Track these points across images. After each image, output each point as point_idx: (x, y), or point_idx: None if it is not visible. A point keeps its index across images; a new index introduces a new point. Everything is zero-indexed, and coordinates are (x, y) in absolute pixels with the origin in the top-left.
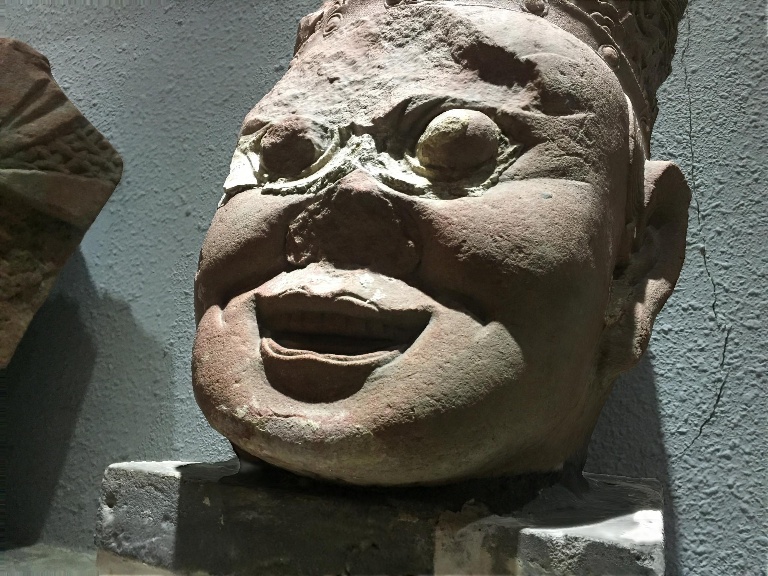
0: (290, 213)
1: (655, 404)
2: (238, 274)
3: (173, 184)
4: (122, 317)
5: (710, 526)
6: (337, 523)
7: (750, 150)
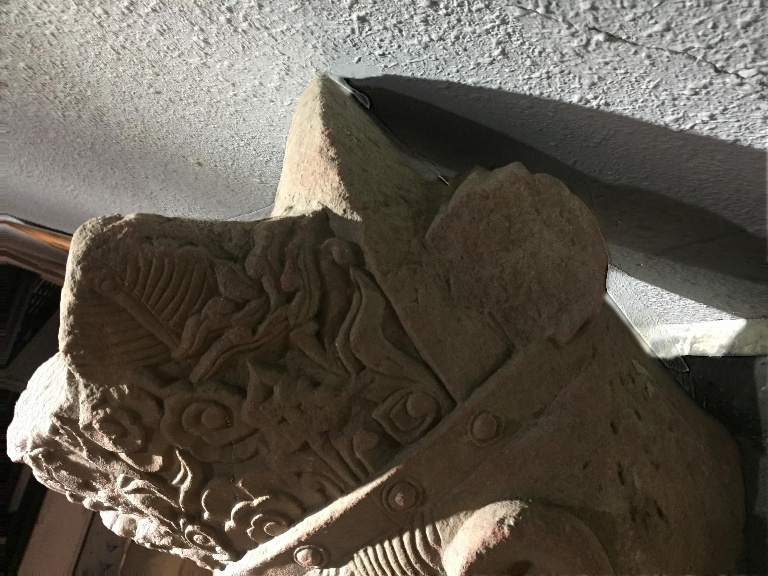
0: None
1: None
2: None
3: None
4: None
5: None
6: None
7: None
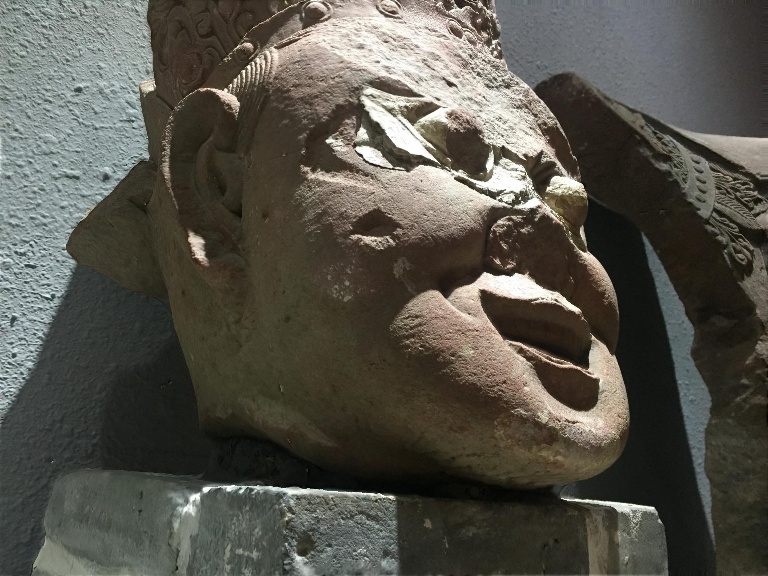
0: (492, 215)
1: None
2: (455, 262)
3: None
4: None
5: None
6: (534, 525)
7: None
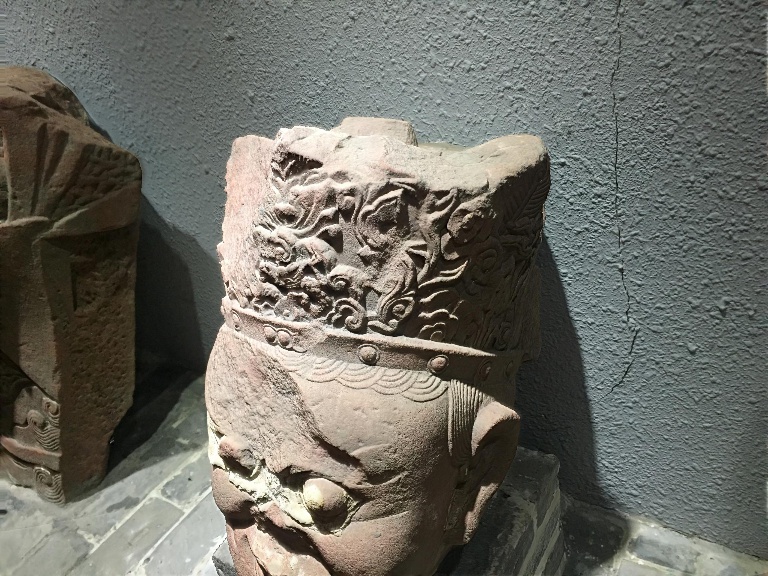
0: (248, 503)
1: (581, 368)
2: None
3: (184, 143)
4: (193, 246)
5: (616, 440)
6: None
7: (670, 188)
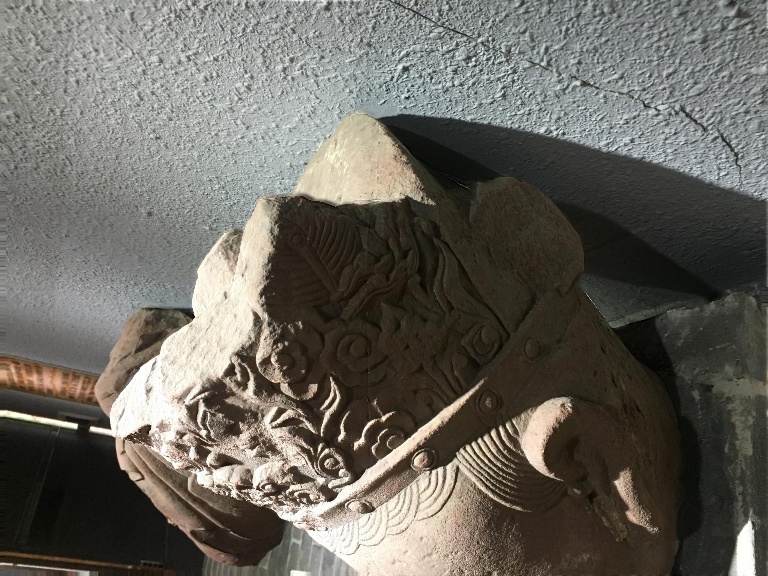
0: None
1: (682, 175)
2: None
3: None
4: None
5: None
6: None
7: None
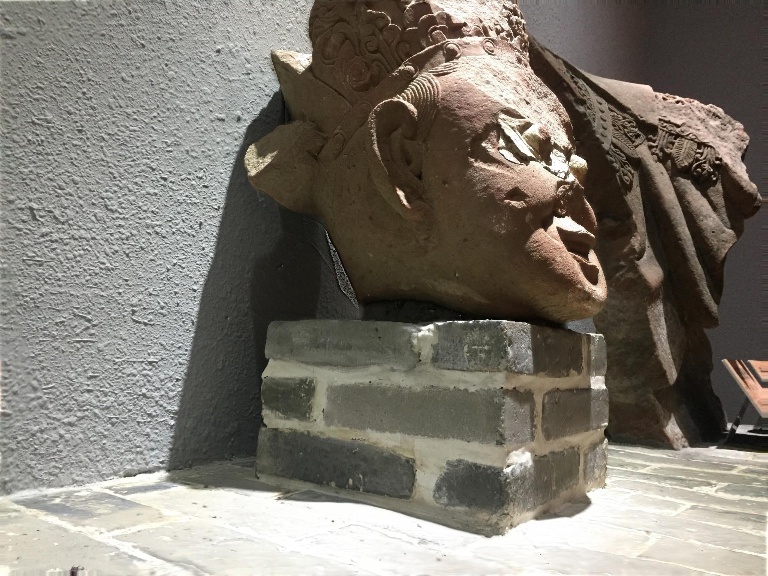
0: None
1: None
2: None
3: None
4: None
5: None
6: None
7: None
